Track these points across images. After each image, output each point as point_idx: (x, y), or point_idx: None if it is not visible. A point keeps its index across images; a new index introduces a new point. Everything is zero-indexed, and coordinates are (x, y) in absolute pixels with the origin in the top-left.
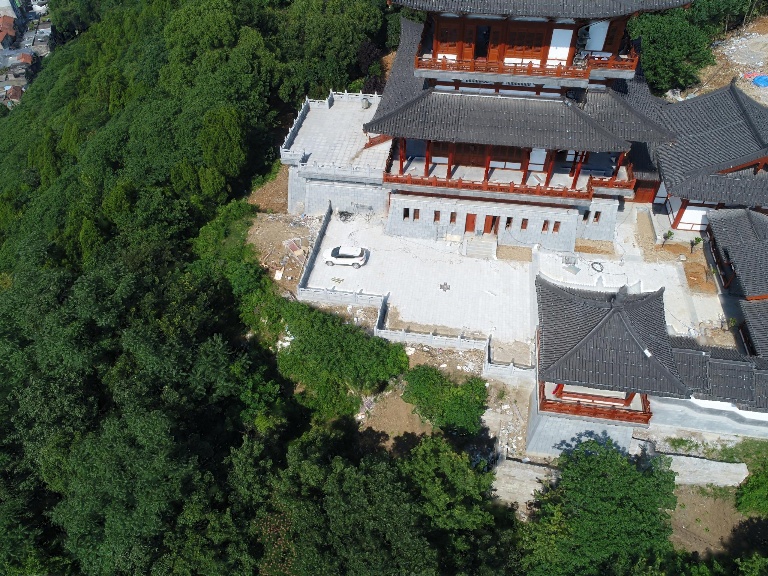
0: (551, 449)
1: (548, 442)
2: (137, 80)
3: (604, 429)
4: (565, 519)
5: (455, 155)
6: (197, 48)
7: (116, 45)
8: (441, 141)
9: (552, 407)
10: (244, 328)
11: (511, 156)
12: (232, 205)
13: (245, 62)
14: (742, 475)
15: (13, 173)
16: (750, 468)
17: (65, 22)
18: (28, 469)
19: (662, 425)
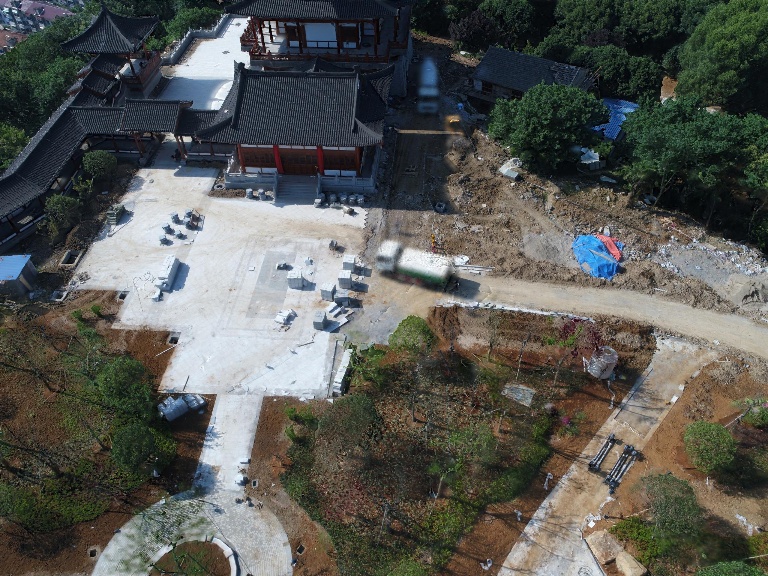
0: None
1: None
2: None
3: None
4: None
5: None
6: None
7: None
8: None
9: None
10: None
11: None
12: None
13: None
14: None
15: None
16: None
17: None
18: None
19: None
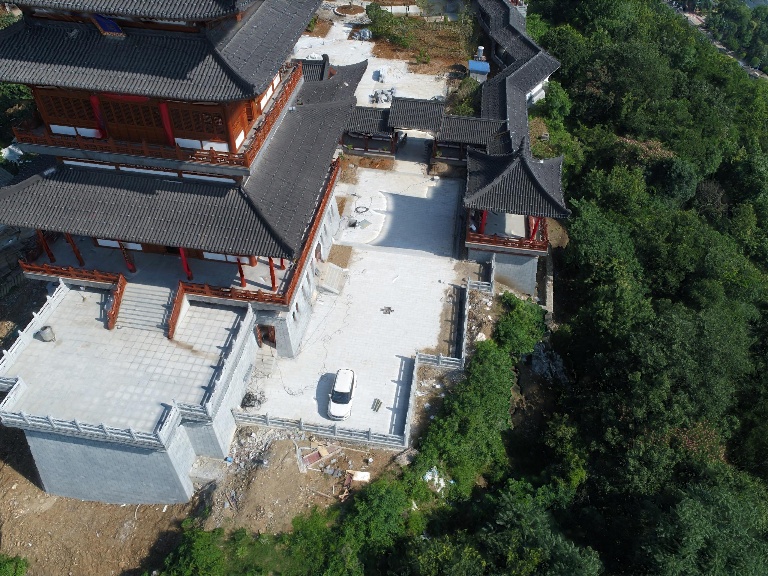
0: None
1: None
2: None
3: None
4: None
5: None
6: None
7: None
8: None
9: None
10: None
11: None
12: None
13: None
14: None
15: None
16: None
17: None
18: None
19: None
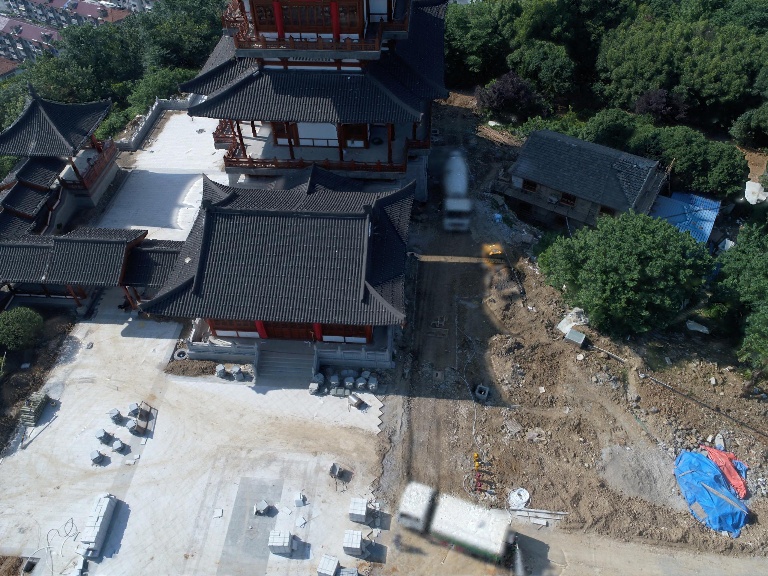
0: None
1: None
2: None
3: None
4: None
5: None
6: None
7: None
8: None
9: None
10: None
11: None
12: None
13: (497, 8)
14: None
15: None
16: None
17: None
18: None
19: None
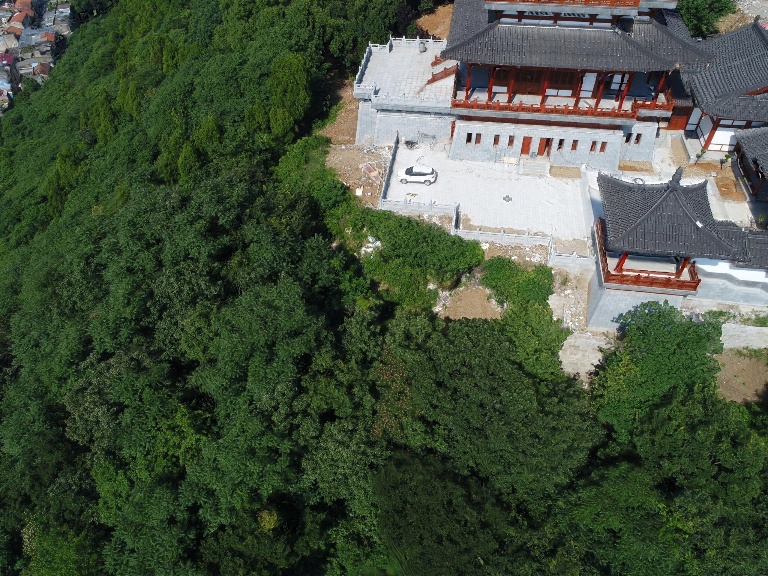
0: (610, 323)
1: (608, 316)
2: (190, 41)
3: (657, 300)
4: (631, 363)
5: (513, 84)
6: (253, 7)
7: (149, 17)
8: (505, 68)
9: (615, 279)
10: (330, 238)
11: (563, 84)
12: (307, 138)
13: (302, 17)
14: None
15: (64, 136)
16: None
17: (84, 2)
18: (161, 348)
19: (705, 300)
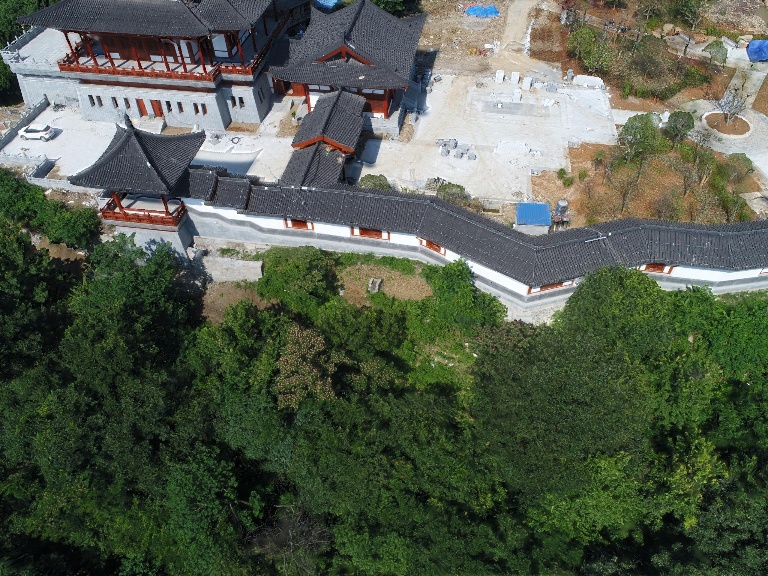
0: None
1: None
2: None
3: (160, 237)
4: None
5: (123, 51)
6: None
7: None
8: (94, 35)
9: (110, 216)
10: None
11: None
12: None
13: None
14: (257, 269)
15: None
16: (266, 265)
17: None
18: None
19: (216, 238)
